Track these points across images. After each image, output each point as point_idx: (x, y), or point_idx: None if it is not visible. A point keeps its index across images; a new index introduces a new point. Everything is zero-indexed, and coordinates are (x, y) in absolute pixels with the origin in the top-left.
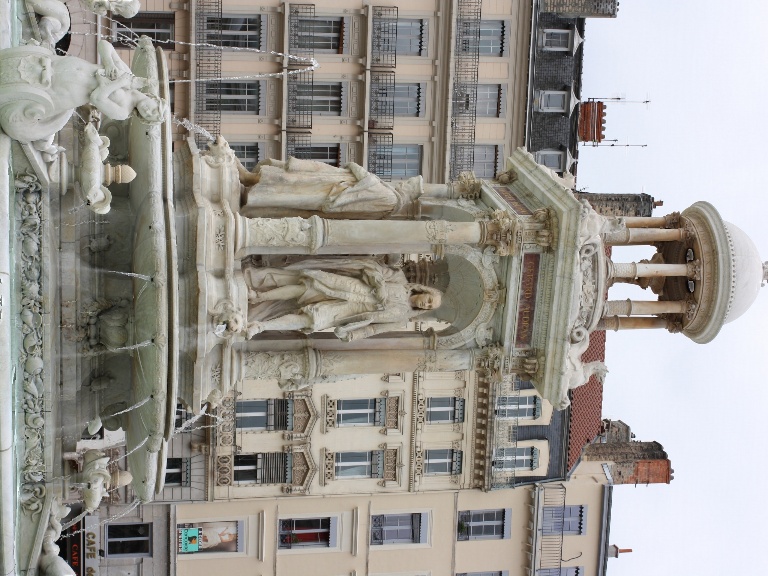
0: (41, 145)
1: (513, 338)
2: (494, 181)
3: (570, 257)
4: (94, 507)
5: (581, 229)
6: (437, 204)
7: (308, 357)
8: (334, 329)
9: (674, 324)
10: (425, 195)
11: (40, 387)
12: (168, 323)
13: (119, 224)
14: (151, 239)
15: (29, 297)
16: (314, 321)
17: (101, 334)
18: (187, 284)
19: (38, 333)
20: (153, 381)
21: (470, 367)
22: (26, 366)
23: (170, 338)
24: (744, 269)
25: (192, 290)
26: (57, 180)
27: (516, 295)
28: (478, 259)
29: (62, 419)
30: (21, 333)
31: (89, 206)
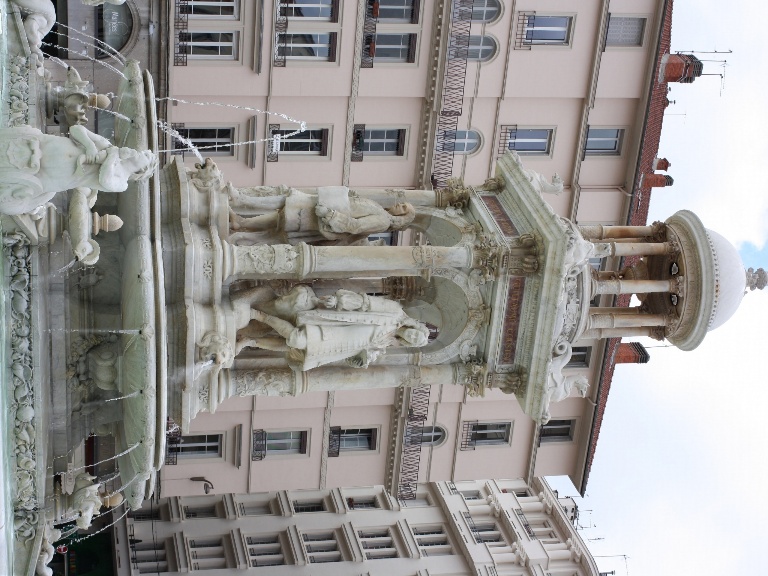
0: (30, 23)
1: (500, 232)
2: None
3: (517, 173)
4: (83, 250)
5: None
6: None
7: None
8: None
9: (675, 279)
10: None
11: None
12: None
13: None
14: None
15: None
16: None
17: None
18: None
19: None
20: (130, 75)
21: (468, 250)
22: None
23: None
24: None
25: None
26: None
27: (487, 213)
28: (443, 215)
29: None
30: (9, 76)
31: (70, 89)
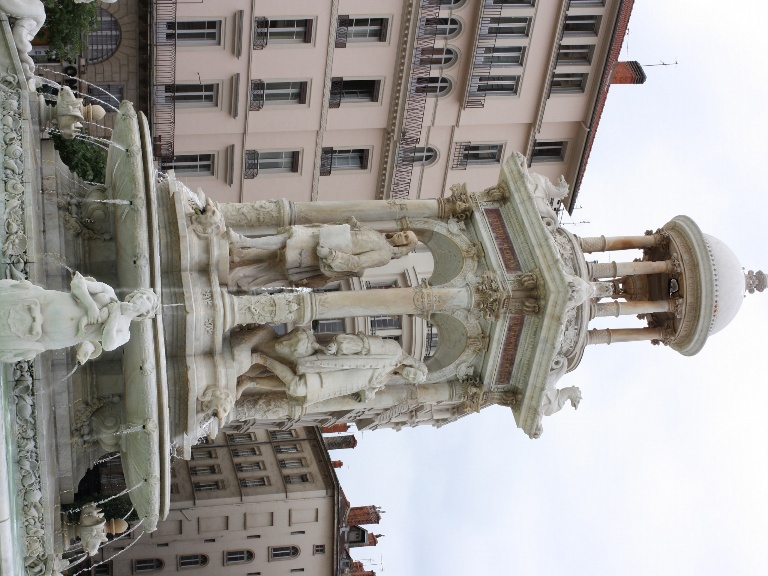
0: (19, 31)
1: (502, 267)
2: None
3: (522, 186)
4: (85, 354)
5: None
6: None
7: None
8: (316, 247)
9: (674, 300)
10: None
11: (20, 166)
12: (138, 120)
13: None
14: None
15: (9, 110)
16: (292, 227)
17: (83, 216)
18: None
19: (17, 132)
20: (127, 141)
21: (469, 293)
22: (6, 151)
23: (141, 127)
24: None
25: None
26: None
27: (490, 236)
28: (445, 230)
29: None
30: (2, 132)
31: (64, 109)
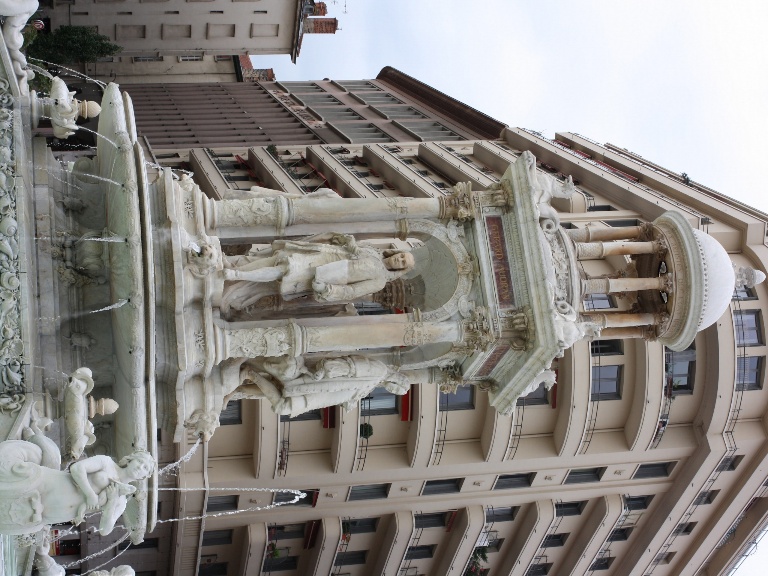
0: (10, 32)
1: (495, 299)
2: None
3: (528, 201)
4: (80, 449)
5: (532, 181)
6: None
7: (292, 325)
8: (312, 280)
9: (661, 315)
10: None
11: (15, 248)
12: (137, 181)
13: (91, 192)
14: (117, 137)
15: (2, 161)
16: (289, 262)
17: (77, 260)
18: (160, 230)
19: (11, 196)
20: (126, 225)
21: (459, 332)
22: (0, 226)
23: (140, 194)
24: (708, 243)
25: (164, 229)
26: (27, 95)
27: (488, 256)
28: (444, 235)
29: (42, 359)
30: None
31: (58, 120)
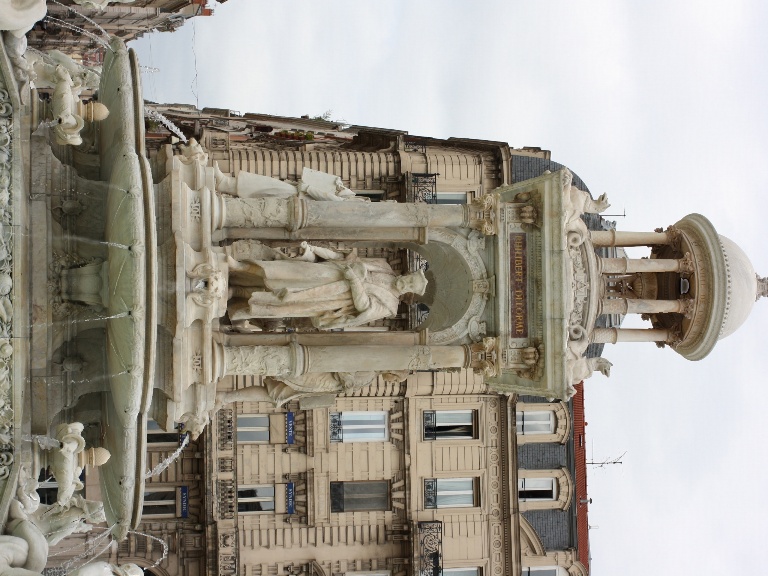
0: None
1: None
2: (517, 216)
3: None
4: None
5: None
6: (444, 242)
7: None
8: None
9: (643, 314)
10: (436, 226)
11: None
12: None
13: None
14: (120, 492)
15: None
16: None
17: None
18: (156, 411)
19: None
20: None
21: None
22: None
23: (131, 525)
24: None
25: (160, 420)
26: None
27: None
28: None
29: None
30: None
31: None
